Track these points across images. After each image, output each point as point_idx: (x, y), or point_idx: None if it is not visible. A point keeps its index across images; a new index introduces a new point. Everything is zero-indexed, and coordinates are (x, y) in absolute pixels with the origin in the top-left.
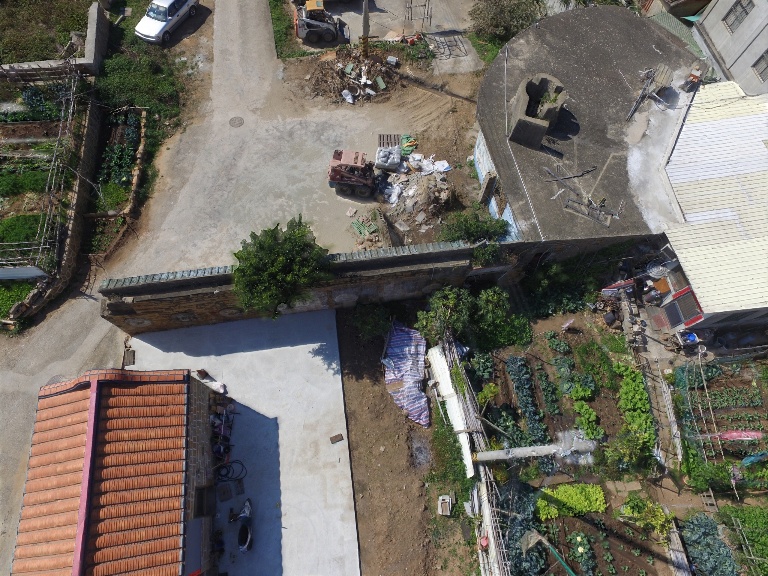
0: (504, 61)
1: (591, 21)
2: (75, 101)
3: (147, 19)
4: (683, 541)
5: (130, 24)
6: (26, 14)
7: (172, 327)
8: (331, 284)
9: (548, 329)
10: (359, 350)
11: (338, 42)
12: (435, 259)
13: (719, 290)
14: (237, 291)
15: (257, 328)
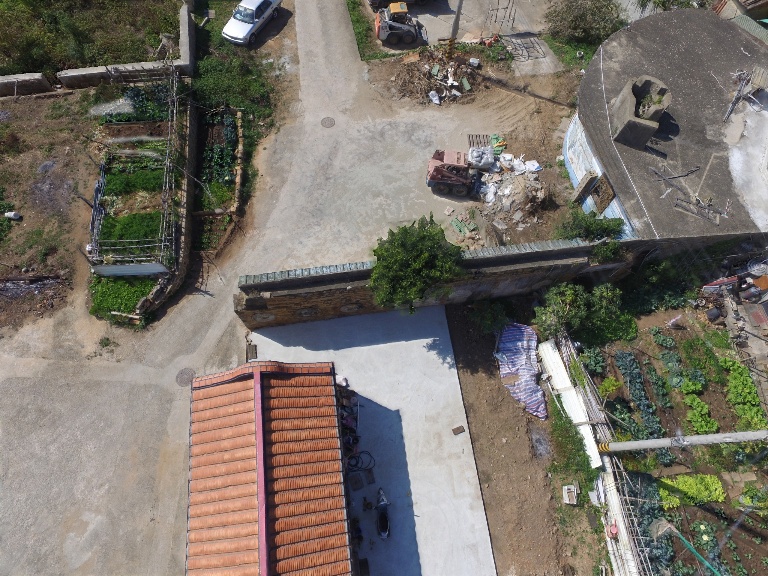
0: (600, 63)
1: (679, 24)
2: (177, 102)
3: (234, 21)
4: None
5: (215, 26)
6: (114, 16)
7: (290, 322)
8: (454, 280)
9: (652, 325)
10: (471, 345)
11: (417, 44)
12: (555, 256)
13: None
14: (374, 287)
15: (371, 323)
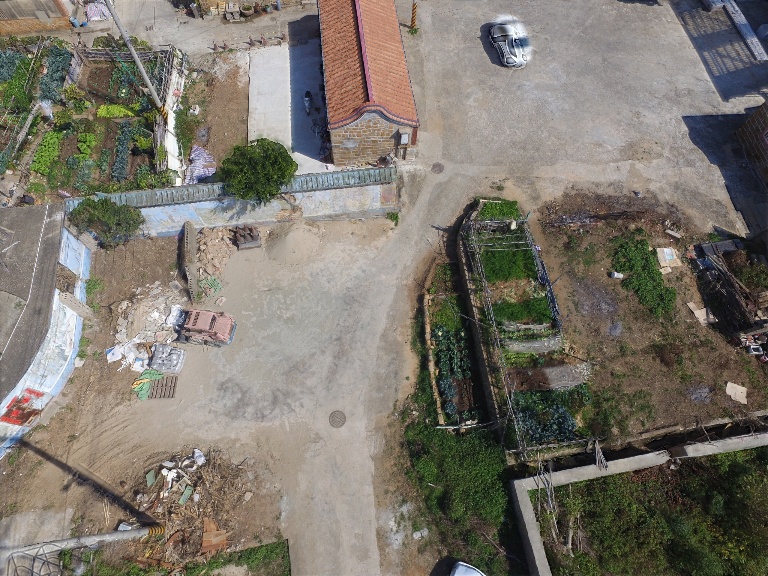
0: None
1: None
2: None
3: None
4: None
5: None
6: None
7: None
8: None
9: None
10: None
11: None
12: None
13: None
14: None
15: None
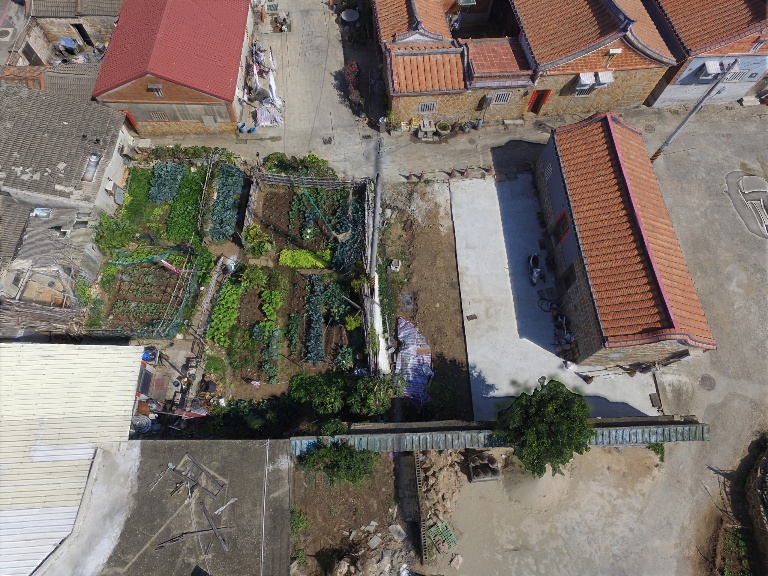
0: None
1: None
2: None
3: None
4: (235, 229)
5: None
6: None
7: None
8: None
9: (273, 387)
10: None
11: None
12: None
13: (115, 367)
14: None
15: None
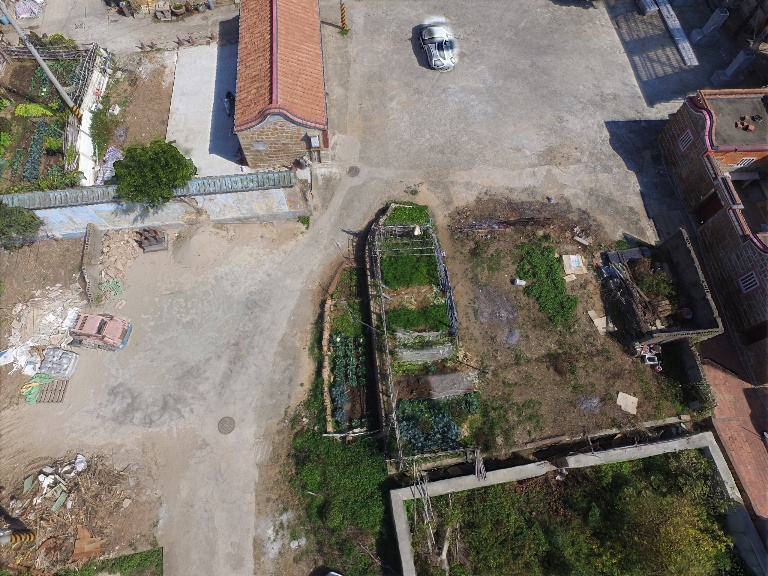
0: None
1: None
2: None
3: None
4: None
5: None
6: None
7: None
8: None
9: None
10: None
11: None
12: None
13: None
14: None
15: None
